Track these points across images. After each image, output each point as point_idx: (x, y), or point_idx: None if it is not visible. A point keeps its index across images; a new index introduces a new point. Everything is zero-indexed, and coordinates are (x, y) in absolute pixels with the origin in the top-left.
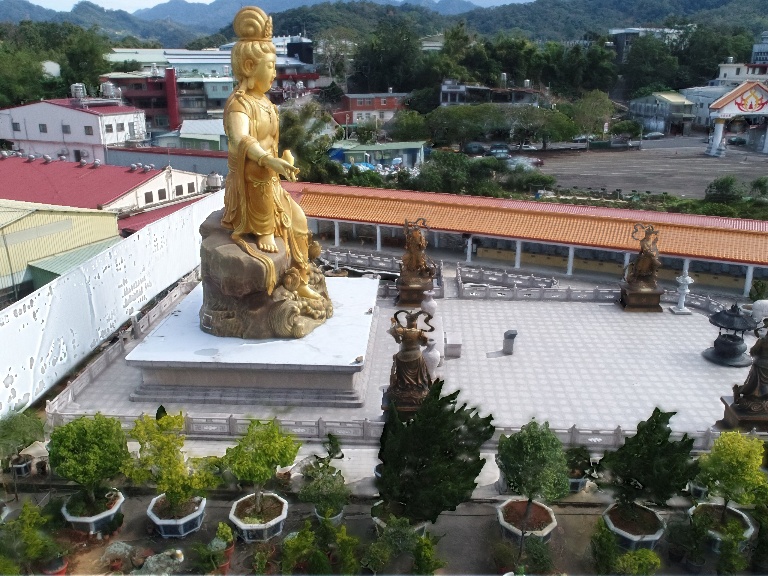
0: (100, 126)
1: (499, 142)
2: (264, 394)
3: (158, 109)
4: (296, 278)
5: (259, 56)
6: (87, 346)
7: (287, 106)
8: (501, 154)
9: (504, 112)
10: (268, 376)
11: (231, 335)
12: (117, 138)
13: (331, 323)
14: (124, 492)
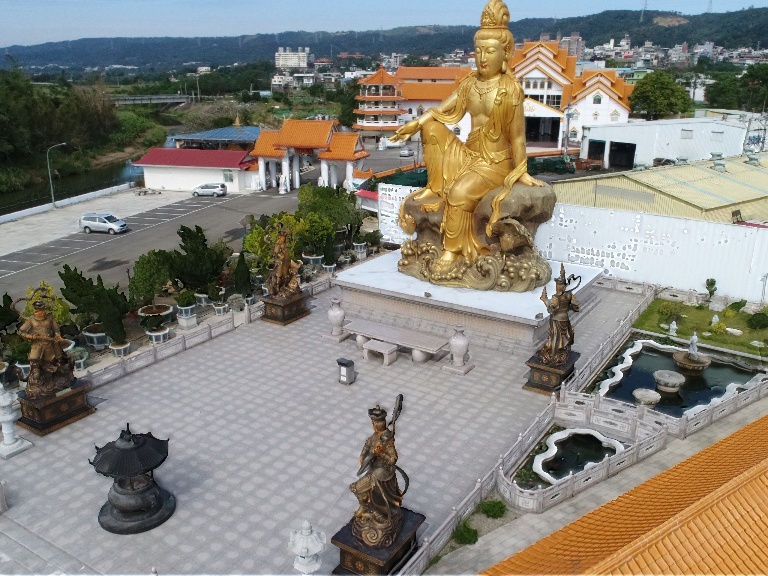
0: None
1: None
2: None
3: None
4: None
5: None
6: None
7: None
8: None
9: None
10: None
11: None
12: None
13: (419, 282)
14: None
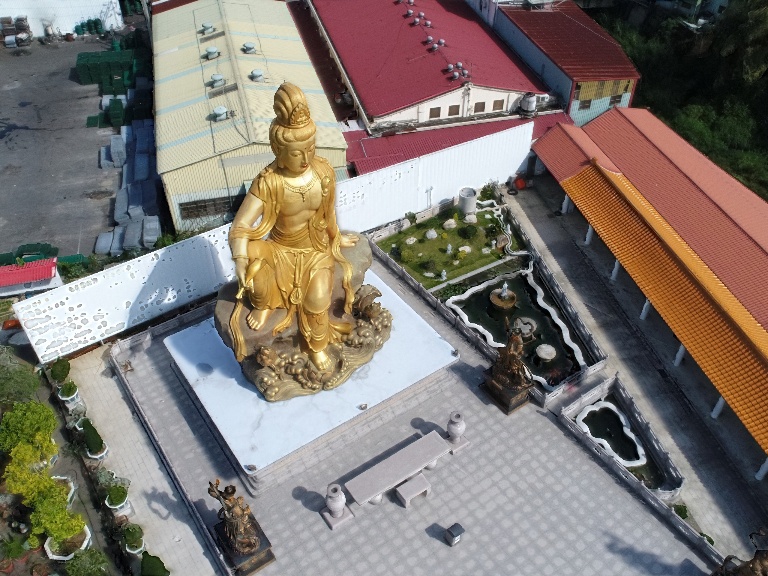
0: None
1: None
2: None
3: None
4: (264, 360)
5: (281, 143)
6: (208, 289)
7: None
8: None
9: None
10: None
11: None
12: None
13: (317, 398)
14: (72, 449)
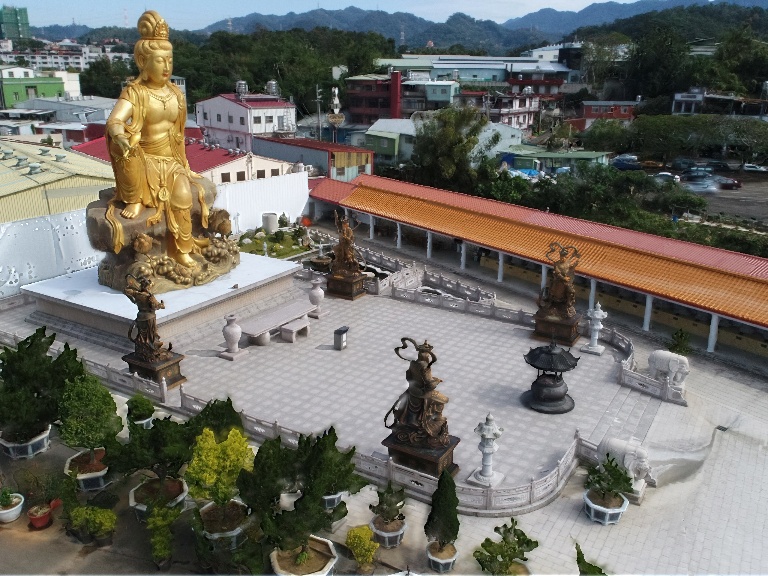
0: (249, 117)
1: (737, 160)
2: (95, 334)
3: (384, 109)
4: (142, 243)
5: (148, 52)
6: None
7: (447, 108)
8: (698, 172)
9: (715, 125)
10: (100, 320)
11: (106, 284)
12: (265, 129)
13: (191, 290)
14: None
